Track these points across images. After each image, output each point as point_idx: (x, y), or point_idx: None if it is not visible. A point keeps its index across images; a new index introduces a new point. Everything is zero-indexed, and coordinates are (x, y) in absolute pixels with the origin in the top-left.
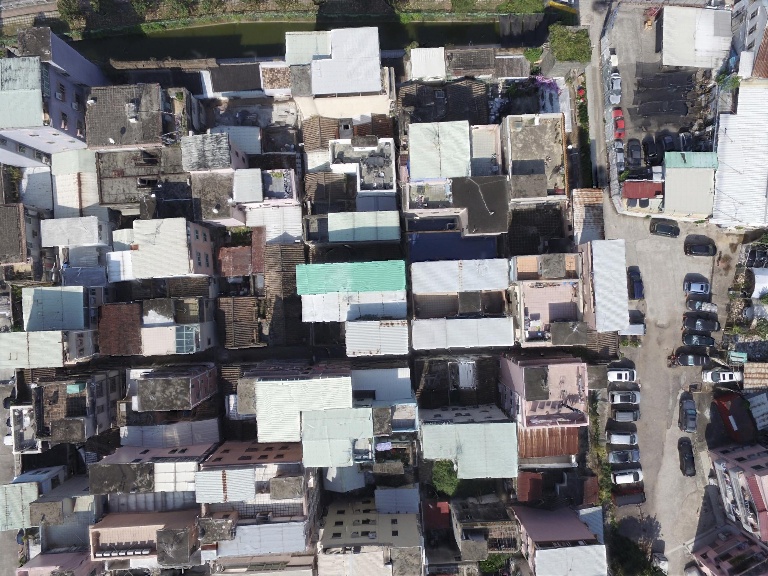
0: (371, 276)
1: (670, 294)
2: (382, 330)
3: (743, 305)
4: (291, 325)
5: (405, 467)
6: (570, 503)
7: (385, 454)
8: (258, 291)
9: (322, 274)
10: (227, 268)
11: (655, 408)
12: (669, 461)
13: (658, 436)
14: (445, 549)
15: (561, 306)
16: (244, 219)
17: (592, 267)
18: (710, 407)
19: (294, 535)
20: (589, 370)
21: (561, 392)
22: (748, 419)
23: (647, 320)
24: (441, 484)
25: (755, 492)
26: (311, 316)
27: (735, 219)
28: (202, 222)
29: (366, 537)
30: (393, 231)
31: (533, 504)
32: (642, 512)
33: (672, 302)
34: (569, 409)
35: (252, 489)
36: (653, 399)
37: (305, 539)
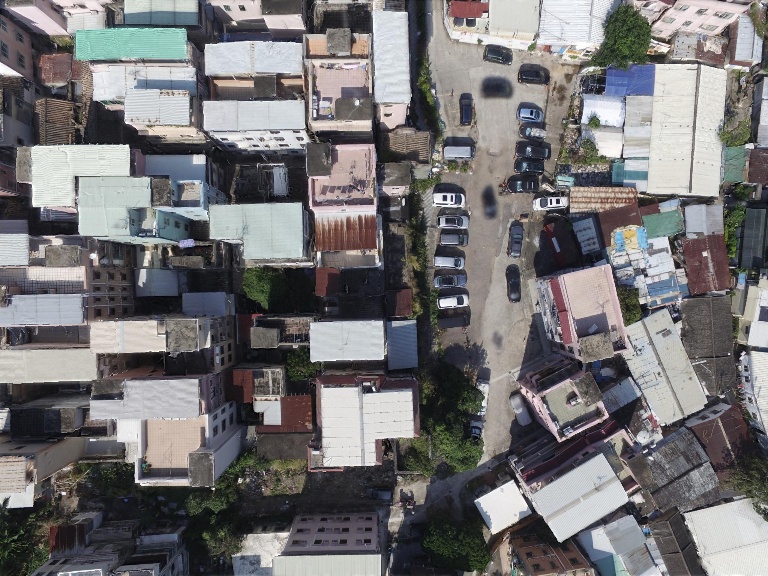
0: (150, 42)
1: (503, 122)
2: (162, 99)
3: (577, 136)
4: (105, 128)
5: (207, 264)
6: (384, 315)
7: (190, 253)
8: (77, 98)
9: (101, 39)
10: (47, 75)
11: (484, 235)
12: (497, 288)
13: (486, 263)
14: (260, 363)
15: (354, 90)
16: (65, 26)
17: (373, 38)
18: (540, 235)
19: (71, 306)
20: (391, 167)
21: (349, 173)
22: (571, 241)
23: (479, 148)
24: (251, 290)
25: (557, 294)
26: (102, 95)
27: (561, 39)
28: (12, 17)
29: (152, 318)
30: (191, 17)
31: (344, 314)
32: (468, 339)
33: (505, 130)
34: (357, 191)
35: (25, 254)
36: (483, 227)
37: (83, 311)
